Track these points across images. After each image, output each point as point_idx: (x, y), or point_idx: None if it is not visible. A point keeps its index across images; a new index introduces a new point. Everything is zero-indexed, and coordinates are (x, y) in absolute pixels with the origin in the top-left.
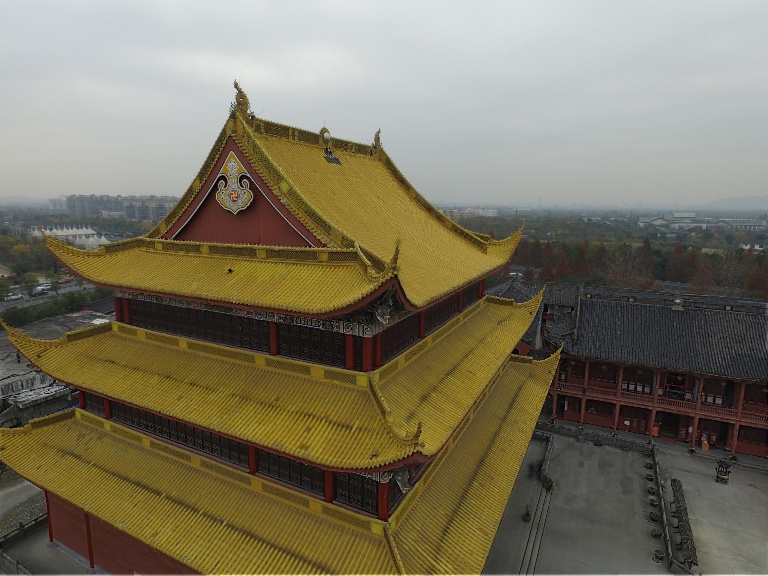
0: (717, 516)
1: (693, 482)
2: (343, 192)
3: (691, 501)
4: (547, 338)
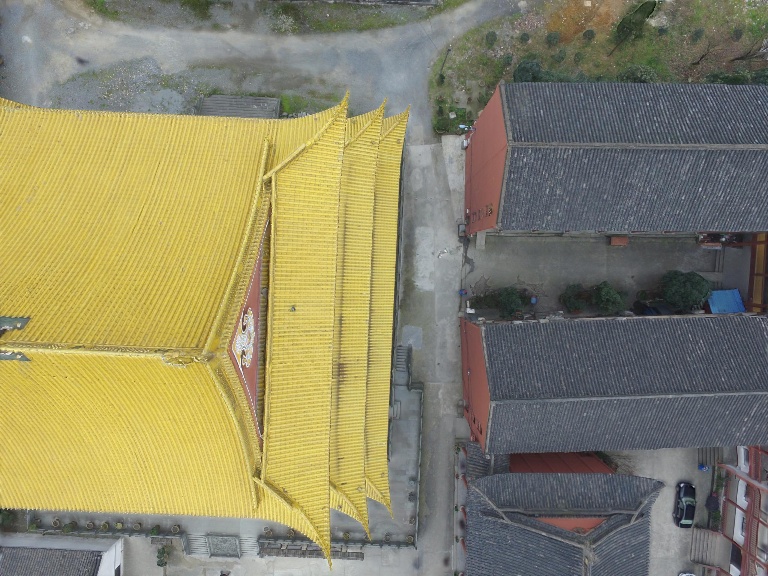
0: (358, 573)
1: (402, 565)
2: (4, 391)
3: (371, 558)
4: (468, 485)
